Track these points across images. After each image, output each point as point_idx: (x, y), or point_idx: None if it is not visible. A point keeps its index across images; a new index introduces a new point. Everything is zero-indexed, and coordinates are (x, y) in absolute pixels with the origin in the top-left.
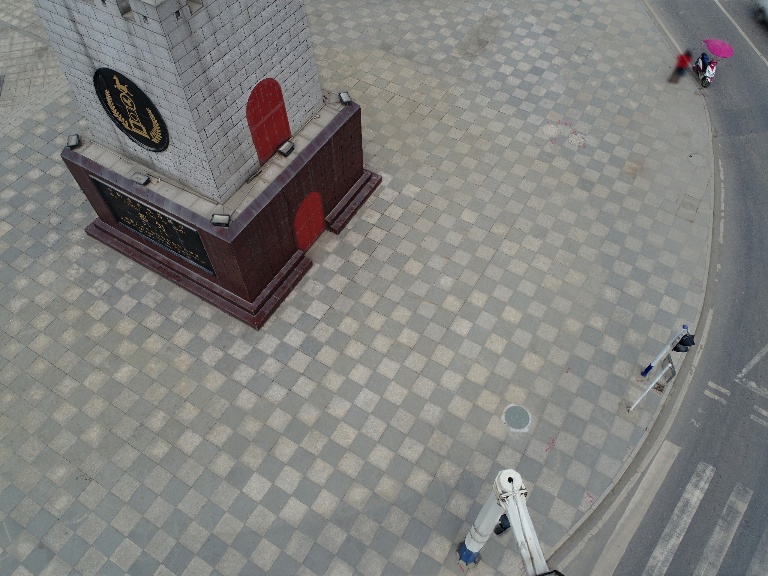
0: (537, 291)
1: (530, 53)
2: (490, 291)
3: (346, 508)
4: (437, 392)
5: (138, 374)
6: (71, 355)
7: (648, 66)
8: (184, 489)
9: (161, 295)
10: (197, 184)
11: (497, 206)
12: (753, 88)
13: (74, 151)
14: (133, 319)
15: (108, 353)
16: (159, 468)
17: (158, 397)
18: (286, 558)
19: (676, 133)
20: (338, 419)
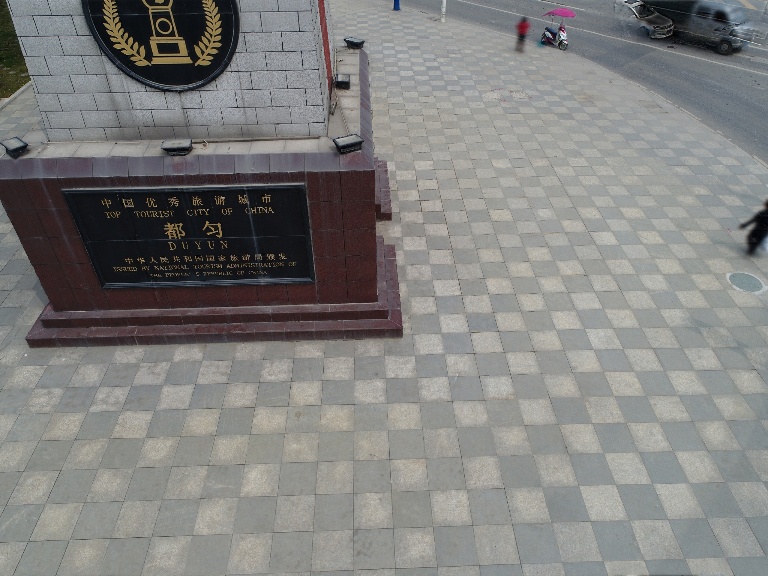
0: (628, 189)
1: (413, 61)
2: (592, 204)
3: (724, 456)
4: (656, 297)
5: (282, 469)
6: (135, 506)
7: (512, 48)
8: (514, 574)
9: (224, 363)
10: (279, 118)
11: (516, 149)
12: (595, 43)
13: (22, 158)
14: (206, 408)
15: (203, 469)
16: (445, 571)
17: (344, 479)
18: (742, 563)
19: (583, 74)
20: (598, 372)
